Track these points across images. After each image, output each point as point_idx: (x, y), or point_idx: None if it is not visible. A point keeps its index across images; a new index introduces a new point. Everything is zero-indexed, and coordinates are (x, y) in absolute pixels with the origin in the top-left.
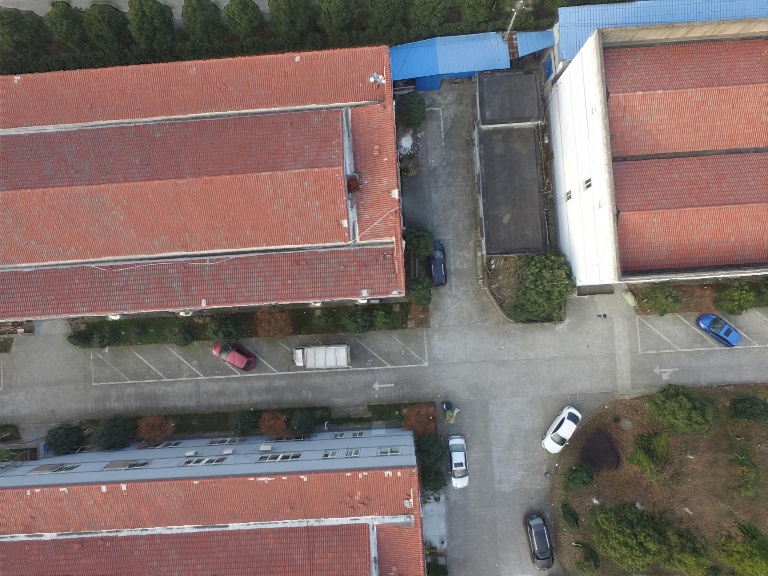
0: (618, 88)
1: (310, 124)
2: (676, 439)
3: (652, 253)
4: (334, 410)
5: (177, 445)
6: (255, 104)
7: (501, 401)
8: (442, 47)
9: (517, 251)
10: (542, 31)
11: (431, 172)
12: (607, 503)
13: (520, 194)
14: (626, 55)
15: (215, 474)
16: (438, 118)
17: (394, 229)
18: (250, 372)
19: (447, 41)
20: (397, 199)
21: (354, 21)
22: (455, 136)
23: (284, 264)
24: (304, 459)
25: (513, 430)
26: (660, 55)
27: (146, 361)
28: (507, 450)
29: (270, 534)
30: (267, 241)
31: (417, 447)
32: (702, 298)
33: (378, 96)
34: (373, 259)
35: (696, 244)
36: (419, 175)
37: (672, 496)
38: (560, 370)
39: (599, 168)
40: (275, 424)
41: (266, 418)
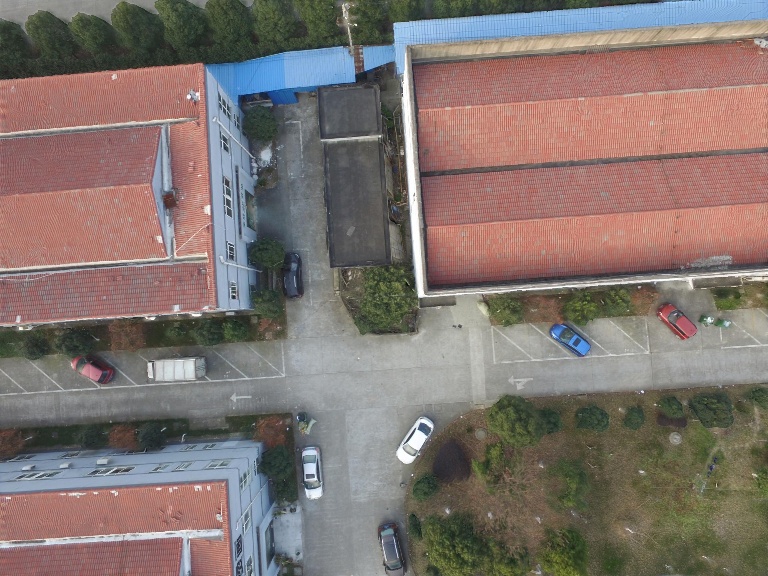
0: (428, 104)
1: (130, 141)
2: (529, 449)
3: (465, 267)
4: (192, 422)
5: (29, 458)
6: (76, 121)
7: (357, 412)
8: (289, 62)
9: (361, 263)
10: (388, 45)
11: (290, 185)
12: (460, 513)
13: (364, 207)
14: (442, 71)
15: (31, 489)
16: (297, 131)
17: (206, 245)
18: (109, 385)
19: (294, 56)
20: (209, 215)
21: (201, 36)
22: (314, 149)
23: (101, 280)
24: (131, 473)
25: (369, 441)
26: (478, 70)
27: (7, 374)
28: (363, 461)
29: (85, 549)
30: (85, 257)
31: (262, 459)
32: (547, 309)
33: (196, 113)
34: (188, 274)
35: (508, 257)
36: (278, 188)
37: (525, 506)
38: (416, 381)
39: (414, 183)
40: (123, 437)
41: (115, 431)
